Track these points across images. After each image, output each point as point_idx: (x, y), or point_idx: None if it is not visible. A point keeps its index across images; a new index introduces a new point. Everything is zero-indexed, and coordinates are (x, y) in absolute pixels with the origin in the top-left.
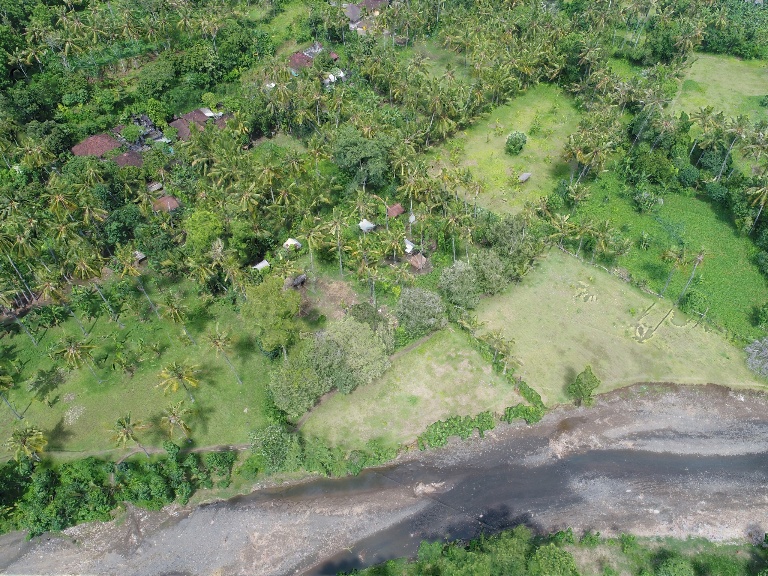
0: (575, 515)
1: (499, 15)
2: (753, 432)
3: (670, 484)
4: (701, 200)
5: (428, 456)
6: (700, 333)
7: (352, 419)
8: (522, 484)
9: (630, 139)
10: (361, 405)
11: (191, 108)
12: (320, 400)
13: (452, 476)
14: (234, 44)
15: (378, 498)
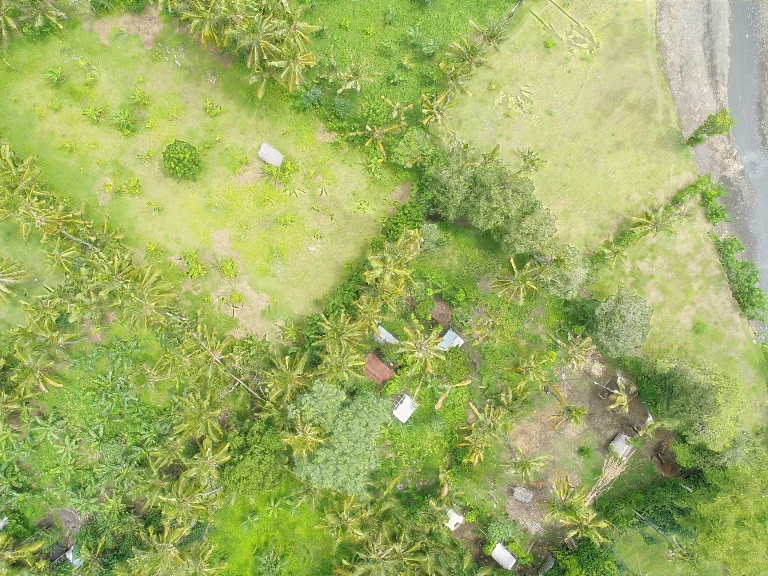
0: None
1: None
2: None
3: (766, 58)
4: None
5: None
6: None
7: None
8: None
9: None
10: None
11: None
12: None
13: None
14: None
15: None
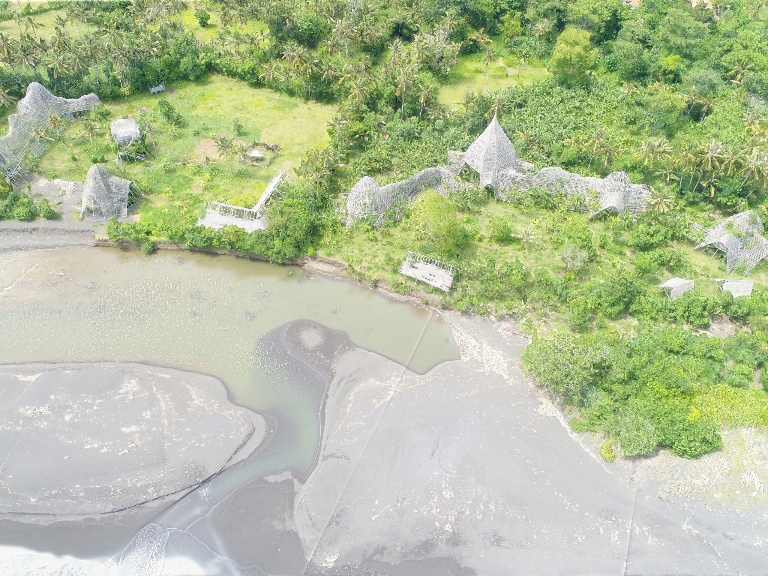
0: None
1: None
2: None
3: None
4: None
5: None
6: None
7: None
8: None
9: None
10: None
11: None
12: None
13: None
14: None
15: None
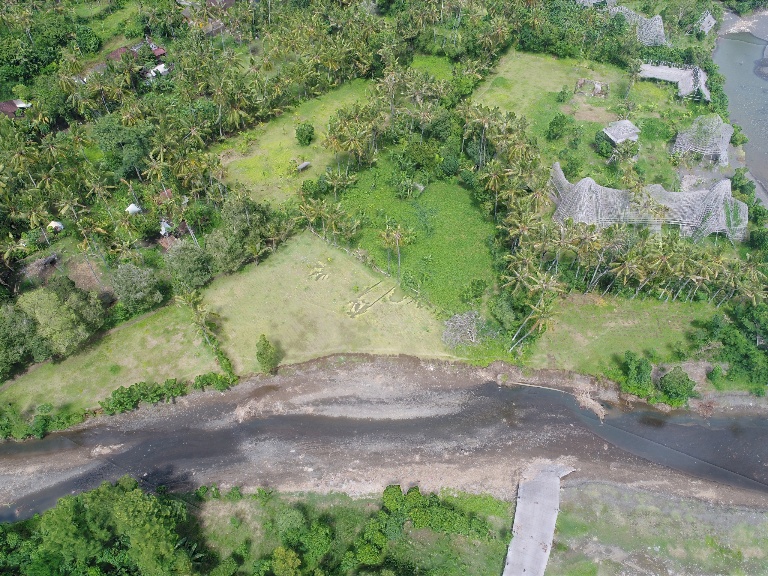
0: (233, 473)
1: (330, 14)
2: (430, 398)
3: (334, 445)
4: (463, 188)
5: (117, 421)
6: (411, 309)
7: (51, 387)
8: (195, 446)
9: (418, 131)
10: (65, 374)
11: (5, 99)
12: (27, 370)
13: (132, 439)
14: (50, 38)
15: (54, 459)
